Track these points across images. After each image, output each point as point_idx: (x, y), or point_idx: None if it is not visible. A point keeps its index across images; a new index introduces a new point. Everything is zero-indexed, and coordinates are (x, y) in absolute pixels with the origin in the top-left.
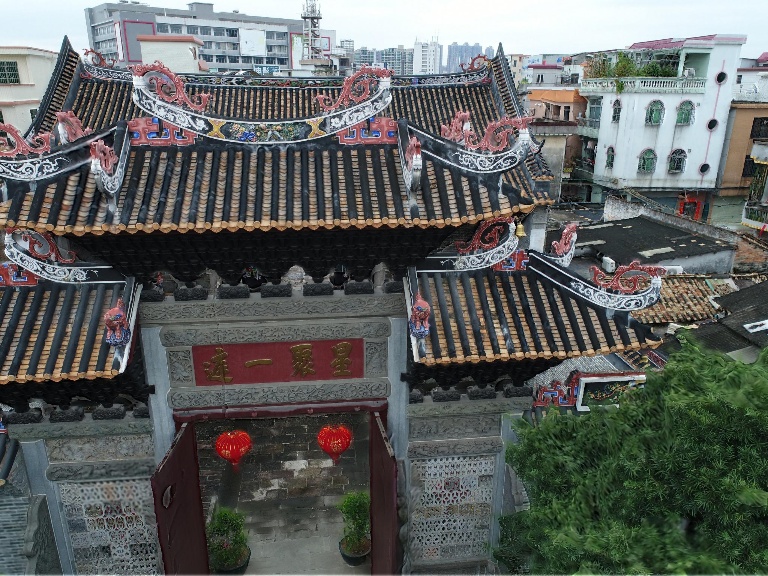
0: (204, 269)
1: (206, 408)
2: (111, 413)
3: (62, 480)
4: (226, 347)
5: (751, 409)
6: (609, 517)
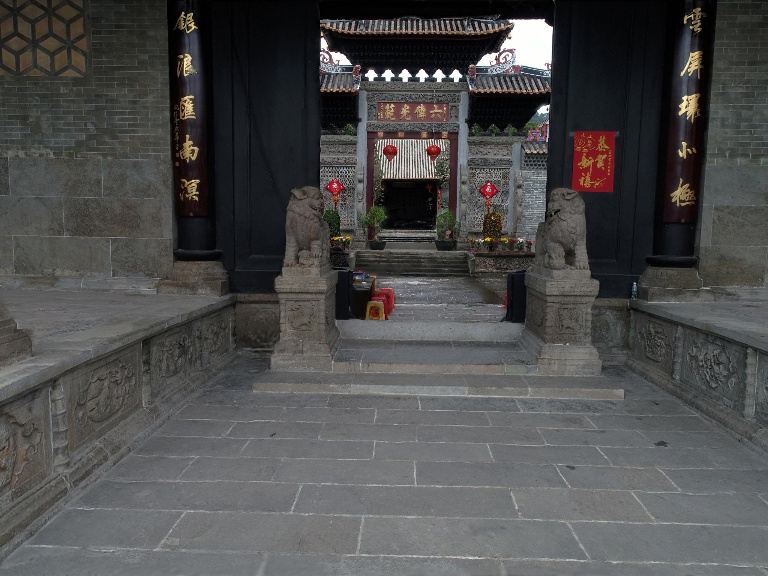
0: (440, 70)
1: None
2: None
3: None
4: None
5: None
6: None
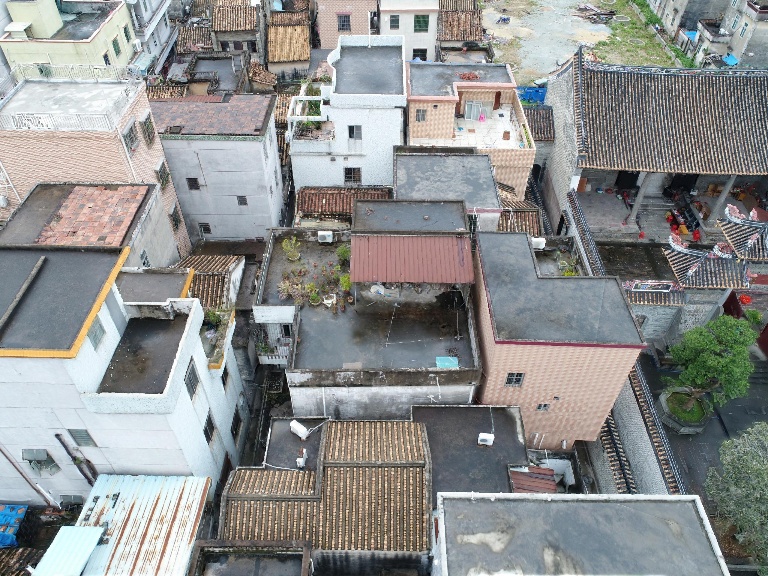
0: None
1: (742, 289)
2: (715, 289)
3: (689, 303)
4: (758, 275)
5: None
6: None
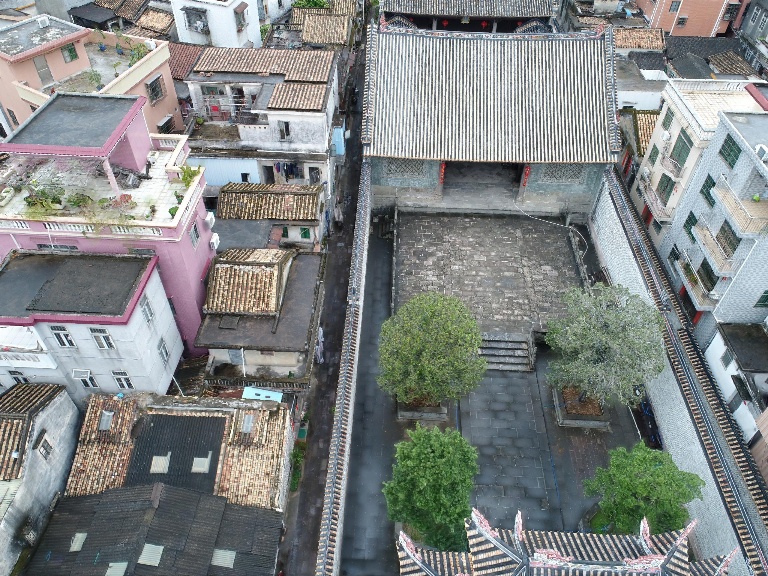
0: None
1: None
2: None
3: None
4: None
5: (442, 436)
6: (459, 467)
